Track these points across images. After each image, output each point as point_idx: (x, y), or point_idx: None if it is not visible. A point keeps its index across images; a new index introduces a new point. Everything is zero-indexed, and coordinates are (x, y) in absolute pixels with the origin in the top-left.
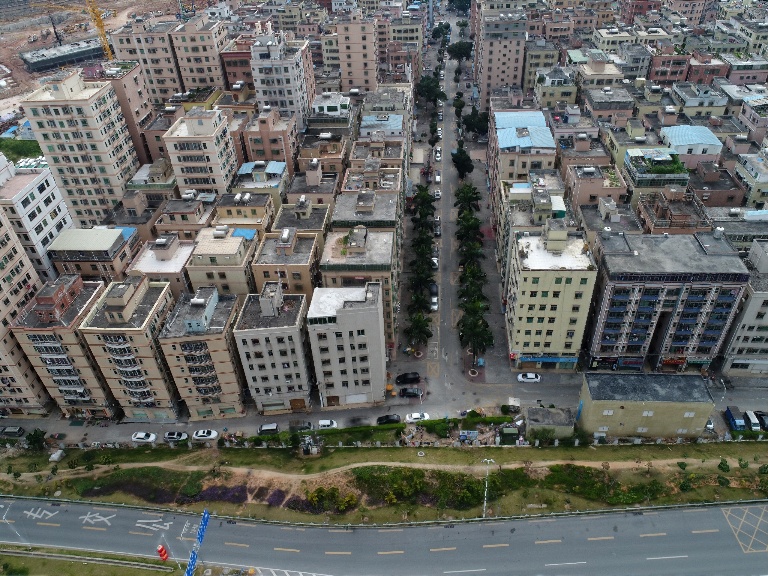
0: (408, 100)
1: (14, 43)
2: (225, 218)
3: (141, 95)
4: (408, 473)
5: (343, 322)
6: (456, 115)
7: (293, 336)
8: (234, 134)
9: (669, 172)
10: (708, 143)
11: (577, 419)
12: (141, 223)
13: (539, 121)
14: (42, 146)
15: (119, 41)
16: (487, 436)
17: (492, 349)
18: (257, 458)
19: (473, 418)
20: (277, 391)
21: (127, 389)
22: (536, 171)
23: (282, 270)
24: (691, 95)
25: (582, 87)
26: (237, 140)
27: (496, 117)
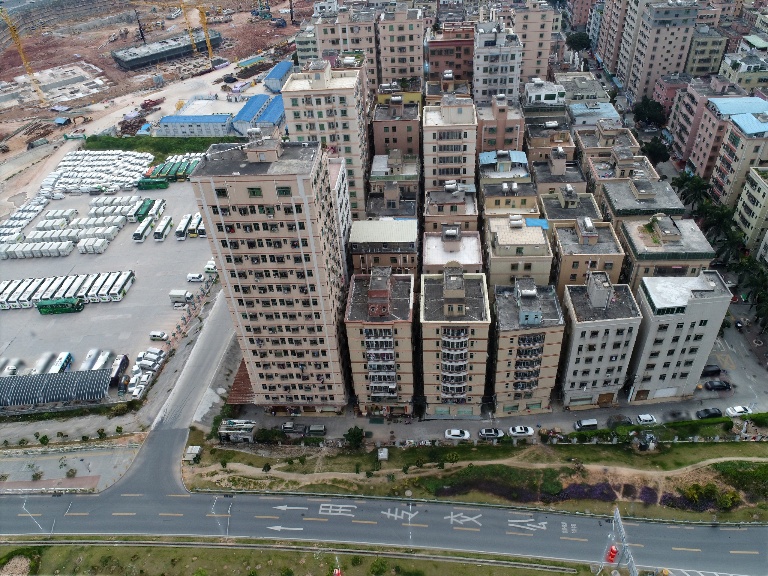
0: None
1: (95, 42)
2: (491, 208)
3: (368, 85)
4: None
5: (690, 312)
6: None
7: (634, 327)
8: None
9: None
10: None
11: None
12: (404, 215)
13: (765, 106)
14: (292, 137)
15: (323, 31)
16: None
17: None
18: (599, 454)
19: None
20: (591, 385)
21: (442, 385)
22: None
23: (594, 260)
24: None
25: None
26: None
27: (716, 103)
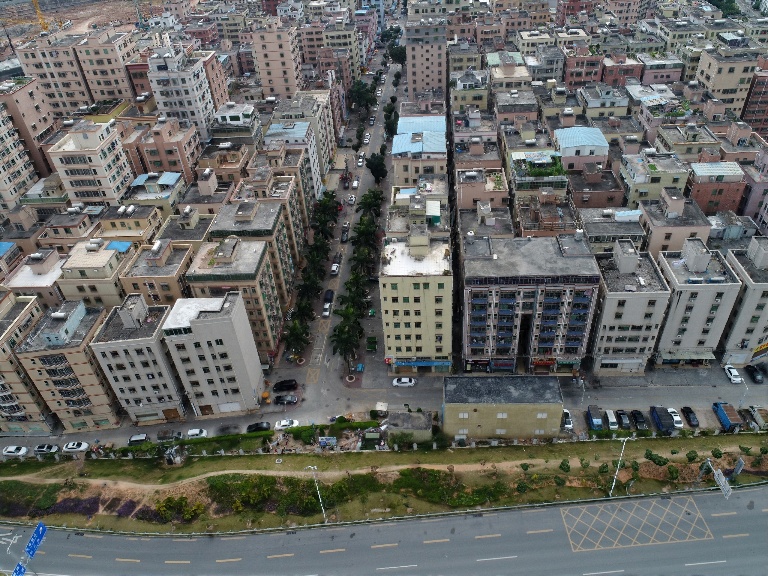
0: (320, 107)
1: None
2: (110, 230)
3: (38, 109)
4: (255, 481)
5: (199, 332)
6: (386, 120)
7: (151, 347)
8: (130, 146)
9: (548, 175)
10: (594, 144)
11: (442, 422)
12: (27, 237)
13: (439, 126)
14: None
15: (24, 56)
16: (350, 441)
17: (374, 354)
18: (118, 469)
19: (340, 424)
20: (147, 402)
21: None
22: (426, 176)
23: (150, 282)
24: (594, 96)
25: (492, 90)
26: (134, 152)
27: (398, 123)
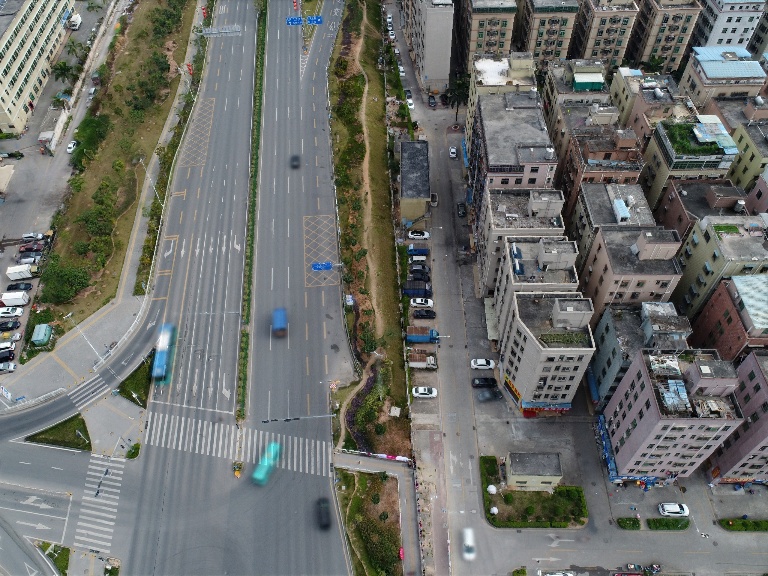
0: None
1: None
2: None
3: None
4: (351, 82)
5: None
6: None
7: (417, 2)
8: None
9: None
10: None
11: None
12: None
13: None
14: None
15: None
16: (395, 129)
17: None
18: None
19: (411, 125)
20: None
21: None
22: (671, 81)
23: None
24: None
25: None
26: None
27: None
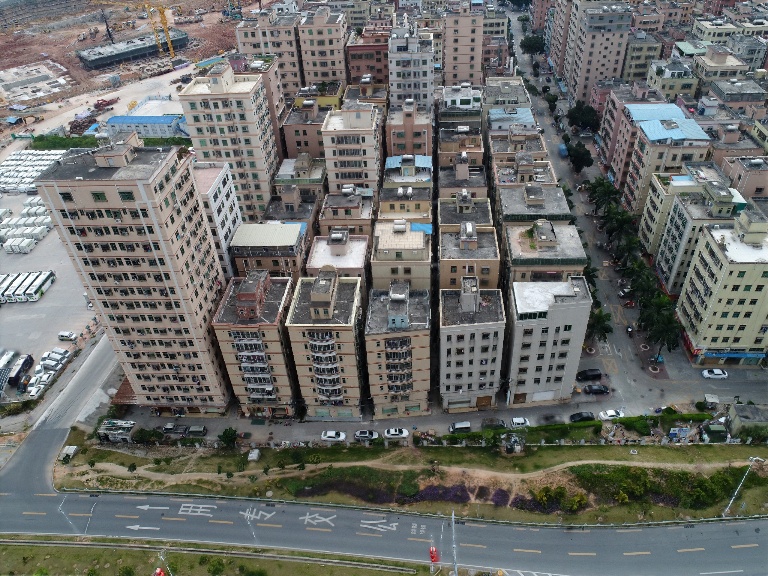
0: None
1: (64, 41)
2: (387, 213)
3: (279, 89)
4: (638, 472)
5: (553, 317)
6: (550, 109)
7: (499, 332)
8: None
9: None
10: None
11: None
12: (301, 218)
13: (677, 113)
14: (194, 141)
15: (244, 35)
16: (692, 433)
17: None
18: (463, 457)
19: (671, 415)
20: (467, 388)
21: (318, 387)
22: (691, 163)
23: (471, 265)
24: None
25: (703, 79)
26: (379, 134)
27: (630, 109)
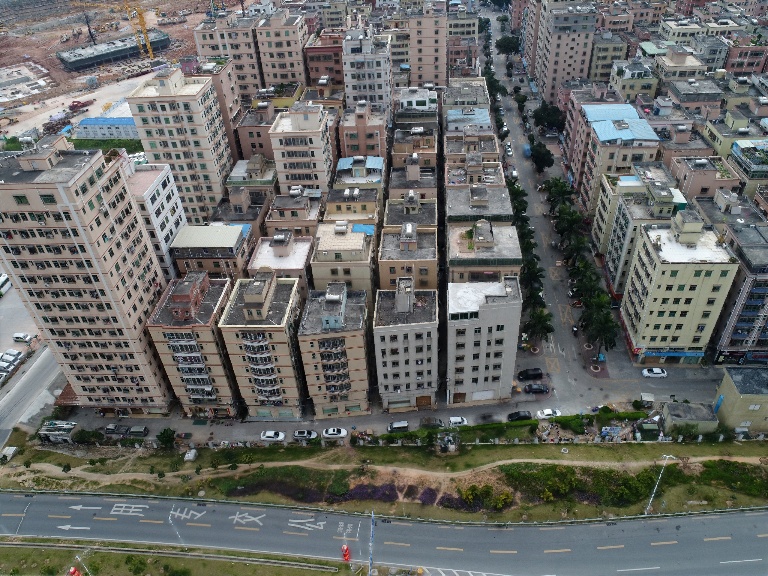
0: None
1: (47, 43)
2: (334, 214)
3: (233, 91)
4: (563, 470)
5: (484, 317)
6: (519, 110)
7: (432, 332)
8: (329, 129)
9: None
10: None
11: None
12: (249, 220)
13: (631, 113)
14: (144, 143)
15: (202, 37)
16: (626, 432)
17: None
18: (397, 456)
19: (607, 414)
20: (406, 388)
21: (256, 387)
22: (640, 164)
23: (409, 265)
24: None
25: (663, 79)
26: (332, 135)
27: (586, 110)
